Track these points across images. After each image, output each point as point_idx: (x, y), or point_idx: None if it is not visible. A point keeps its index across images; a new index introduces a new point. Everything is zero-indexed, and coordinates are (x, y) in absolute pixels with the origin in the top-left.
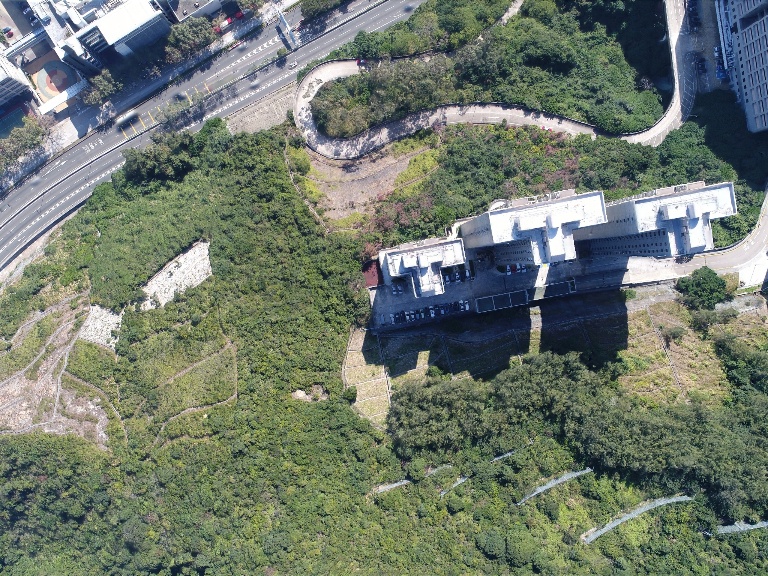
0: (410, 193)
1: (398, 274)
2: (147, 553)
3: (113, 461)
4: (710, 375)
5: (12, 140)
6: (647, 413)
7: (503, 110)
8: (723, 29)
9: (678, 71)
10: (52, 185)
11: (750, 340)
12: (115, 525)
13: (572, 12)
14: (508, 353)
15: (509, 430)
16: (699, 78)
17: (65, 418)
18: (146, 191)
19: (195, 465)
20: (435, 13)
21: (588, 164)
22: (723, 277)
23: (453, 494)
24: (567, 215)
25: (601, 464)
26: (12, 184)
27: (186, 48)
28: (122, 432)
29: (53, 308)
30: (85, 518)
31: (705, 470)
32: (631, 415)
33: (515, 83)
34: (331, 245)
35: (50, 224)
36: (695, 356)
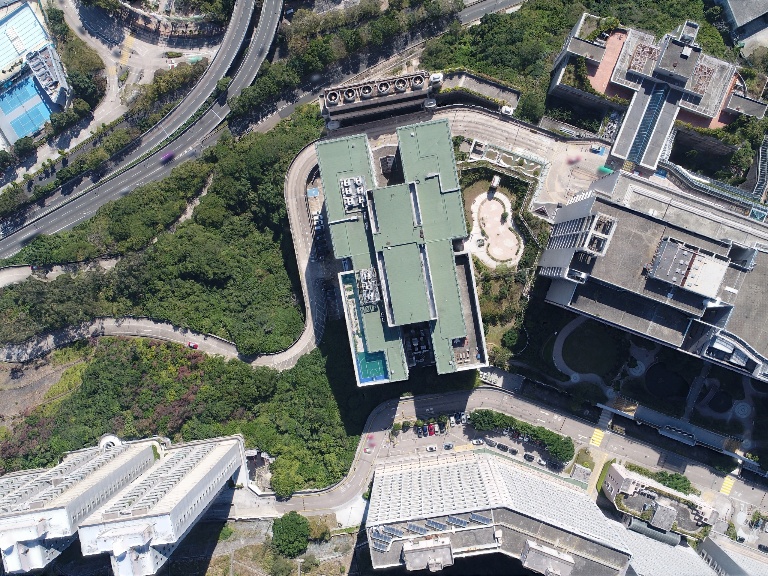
0: (50, 411)
1: None
2: None
3: None
4: None
5: None
6: None
7: (154, 324)
8: (342, 262)
9: (309, 297)
10: None
11: None
12: None
13: (247, 214)
14: None
15: None
16: (328, 305)
17: None
18: None
19: None
20: (111, 217)
21: (202, 397)
22: (311, 523)
23: None
24: (21, 534)
25: None
26: None
27: None
28: None
29: None
30: None
31: None
32: None
33: (165, 298)
34: None
35: None
36: None
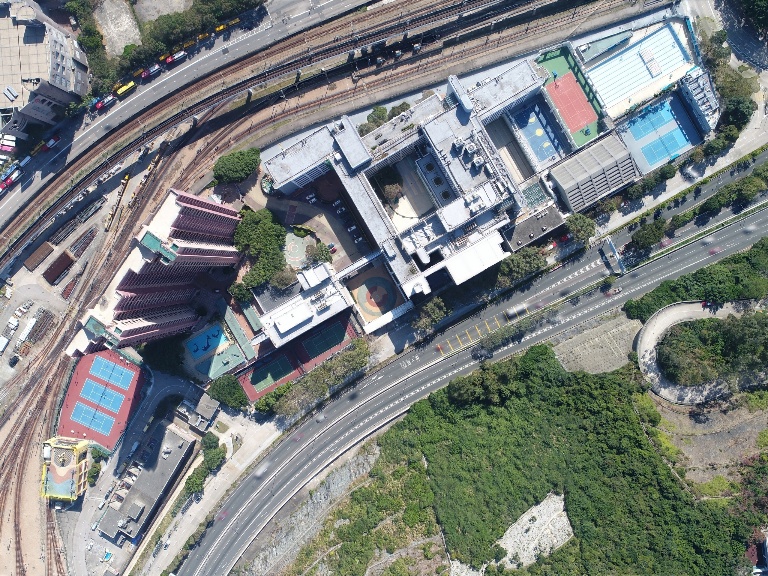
0: None
1: None
2: None
3: None
4: None
5: (344, 364)
6: None
7: None
8: None
9: None
10: (368, 399)
11: None
12: None
13: None
14: None
15: None
16: None
17: None
18: (469, 415)
19: None
20: None
21: None
22: None
23: None
24: None
25: None
26: (328, 395)
27: (518, 277)
28: None
29: (402, 551)
30: None
31: None
32: None
33: None
34: (705, 518)
35: (364, 436)
36: None
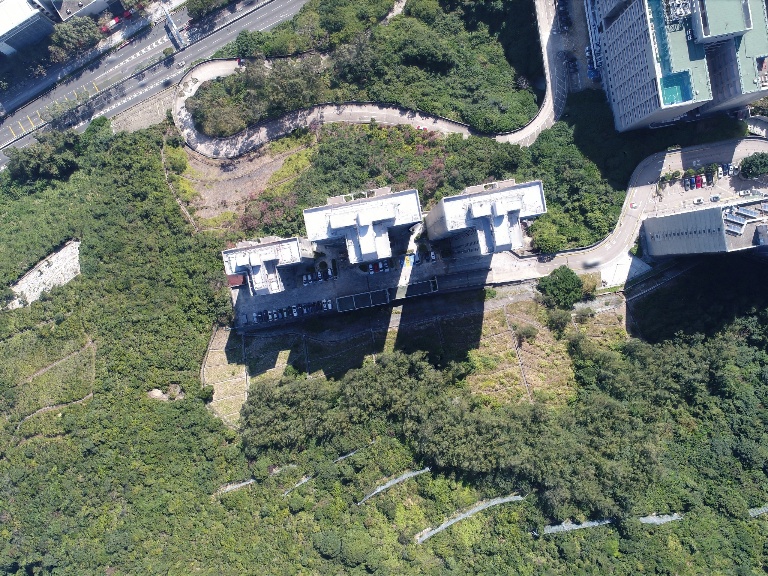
0: (280, 192)
1: (234, 272)
2: (0, 552)
3: None
4: (559, 375)
5: None
6: (489, 413)
7: (379, 109)
8: (591, 28)
9: (550, 70)
10: None
11: (604, 340)
12: None
13: (457, 12)
14: (363, 352)
15: (351, 429)
16: (570, 77)
17: None
18: (31, 190)
19: (46, 464)
20: (318, 12)
21: (453, 163)
22: (582, 276)
23: (296, 494)
24: (377, 213)
25: None
26: None
27: (70, 47)
28: None
29: None
30: None
31: (532, 470)
32: (470, 414)
33: (391, 82)
34: (197, 244)
35: None
36: (546, 356)
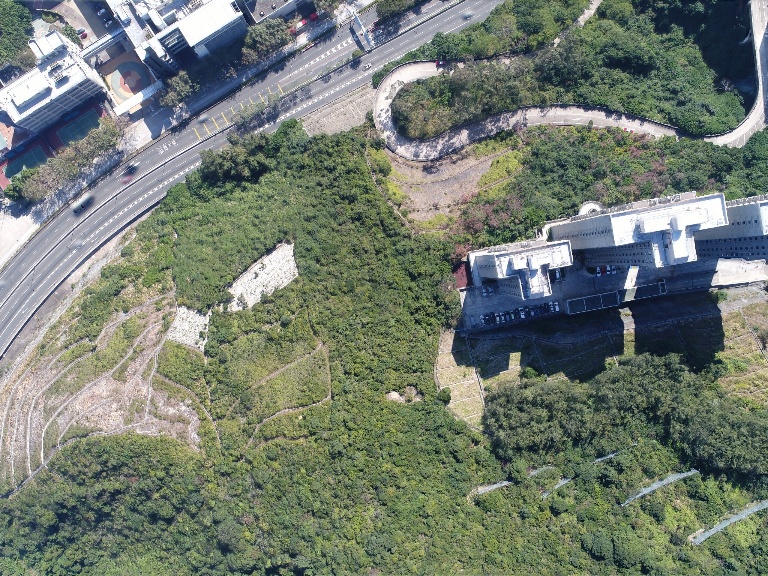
0: (495, 195)
1: (506, 276)
2: (243, 554)
3: (207, 462)
4: None
5: (89, 141)
6: (750, 414)
7: (584, 112)
8: None
9: (762, 73)
10: (126, 186)
11: None
12: (208, 526)
13: (648, 14)
14: (603, 354)
15: (612, 431)
16: None
17: (157, 419)
18: (222, 192)
19: (293, 466)
20: (512, 15)
21: (676, 166)
22: None
23: (556, 495)
24: (691, 217)
25: (706, 465)
26: (85, 185)
27: (263, 49)
28: (214, 433)
29: (137, 309)
30: (175, 519)
31: None
32: (736, 416)
33: (597, 85)
34: (419, 247)
35: (123, 225)
36: None
